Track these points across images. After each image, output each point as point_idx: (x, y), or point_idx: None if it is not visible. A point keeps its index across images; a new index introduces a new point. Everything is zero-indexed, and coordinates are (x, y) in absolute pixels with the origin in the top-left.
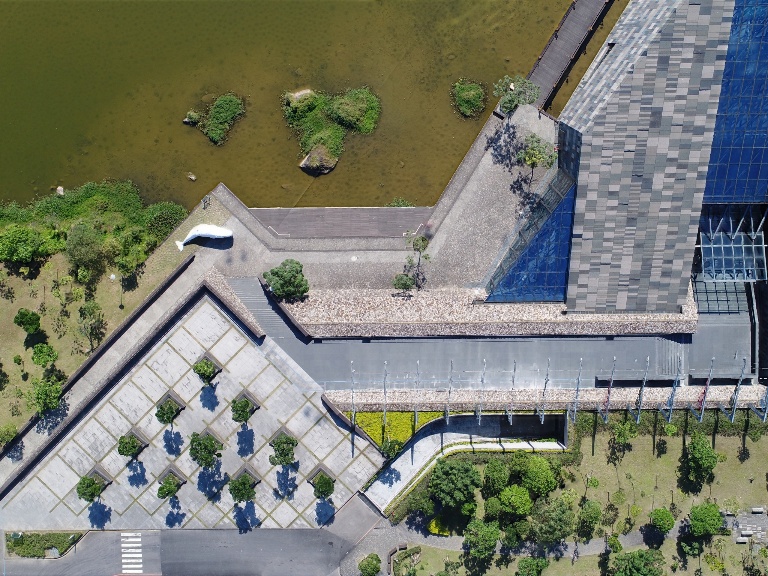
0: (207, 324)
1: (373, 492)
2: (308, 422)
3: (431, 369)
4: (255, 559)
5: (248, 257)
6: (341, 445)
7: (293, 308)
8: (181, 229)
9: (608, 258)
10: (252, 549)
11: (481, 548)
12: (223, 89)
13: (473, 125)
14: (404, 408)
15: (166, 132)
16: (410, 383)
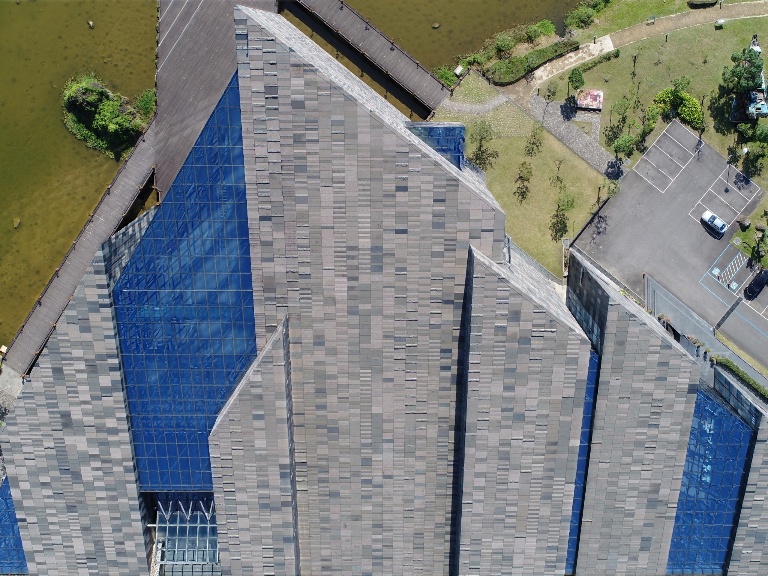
0: None
1: None
2: None
3: None
4: None
5: None
6: None
7: None
8: None
9: (58, 539)
10: None
11: None
12: None
13: None
14: None
15: None
16: None
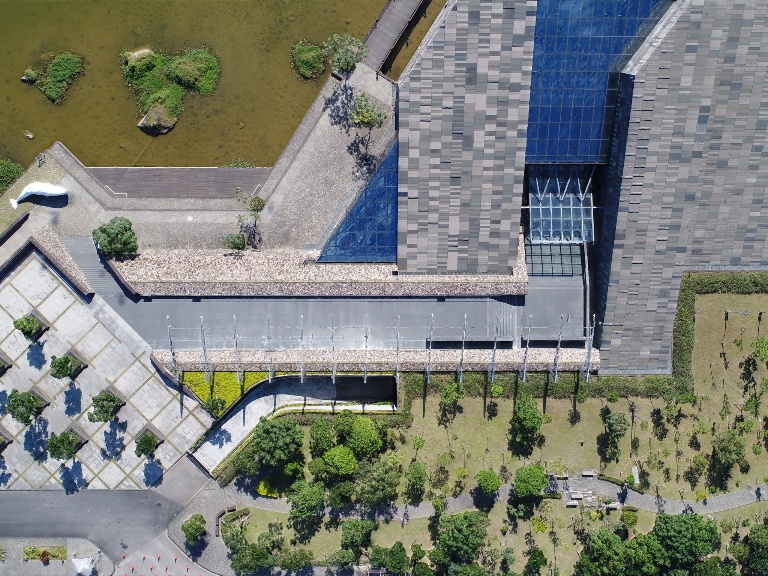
0: (35, 281)
1: (202, 453)
2: (137, 381)
3: (261, 329)
4: (82, 520)
5: (83, 216)
6: (170, 405)
7: (122, 266)
8: (15, 187)
9: (435, 218)
10: (79, 510)
11: (301, 507)
12: (62, 47)
13: (313, 87)
14: (233, 368)
15: (4, 90)
16: (240, 343)
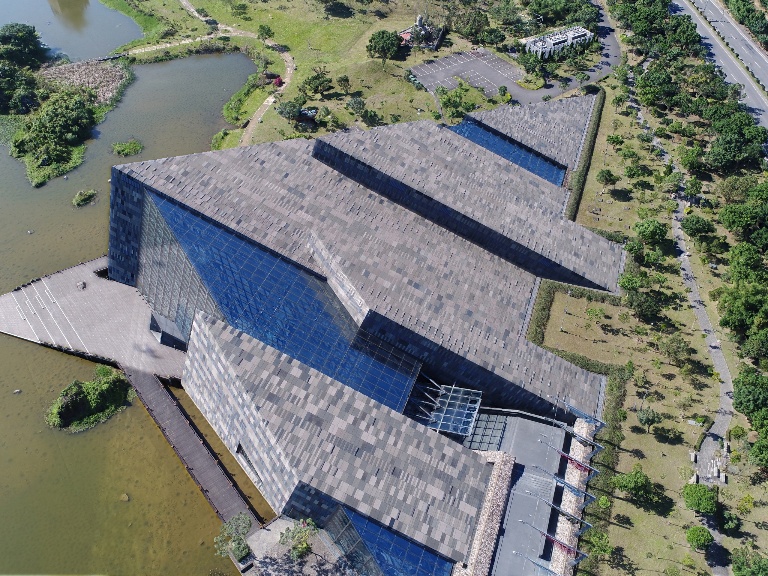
0: None
1: None
2: None
3: None
4: None
5: None
6: None
7: None
8: None
9: (423, 505)
10: None
11: None
12: None
13: None
14: None
15: None
16: None
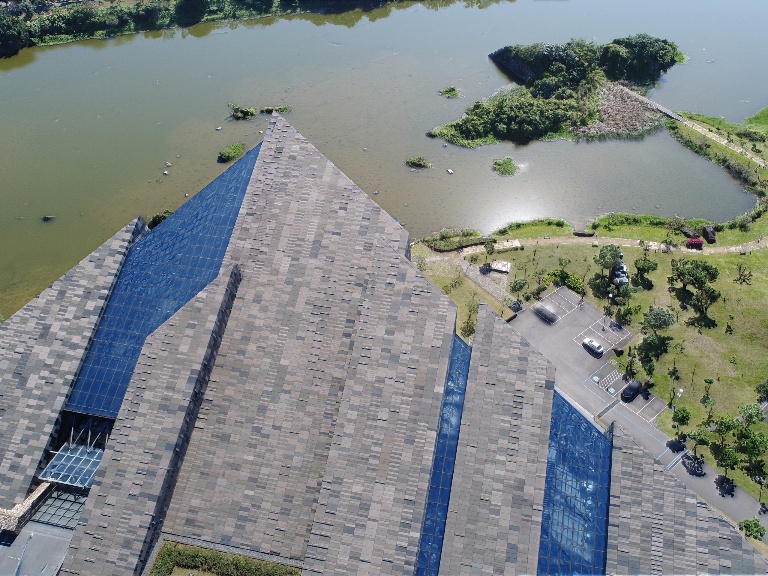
0: None
1: None
2: None
3: None
4: None
5: None
6: None
7: None
8: None
9: None
10: None
11: None
12: None
13: None
14: None
15: None
16: None
